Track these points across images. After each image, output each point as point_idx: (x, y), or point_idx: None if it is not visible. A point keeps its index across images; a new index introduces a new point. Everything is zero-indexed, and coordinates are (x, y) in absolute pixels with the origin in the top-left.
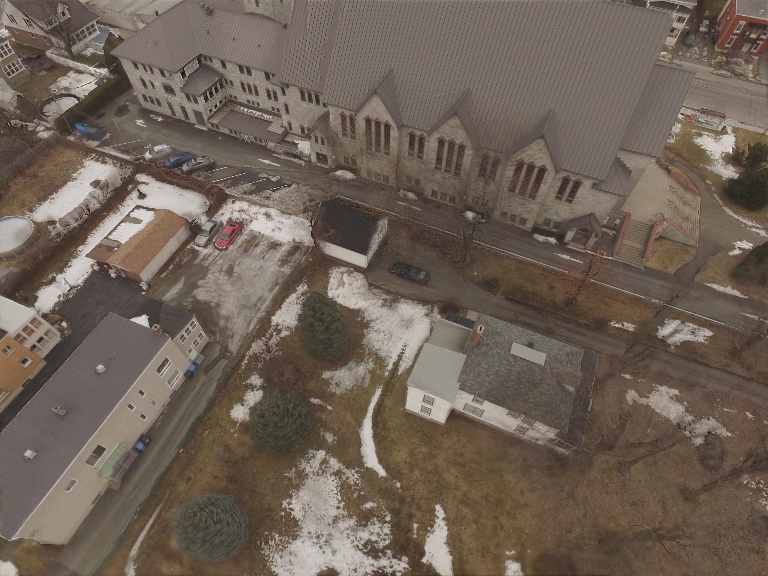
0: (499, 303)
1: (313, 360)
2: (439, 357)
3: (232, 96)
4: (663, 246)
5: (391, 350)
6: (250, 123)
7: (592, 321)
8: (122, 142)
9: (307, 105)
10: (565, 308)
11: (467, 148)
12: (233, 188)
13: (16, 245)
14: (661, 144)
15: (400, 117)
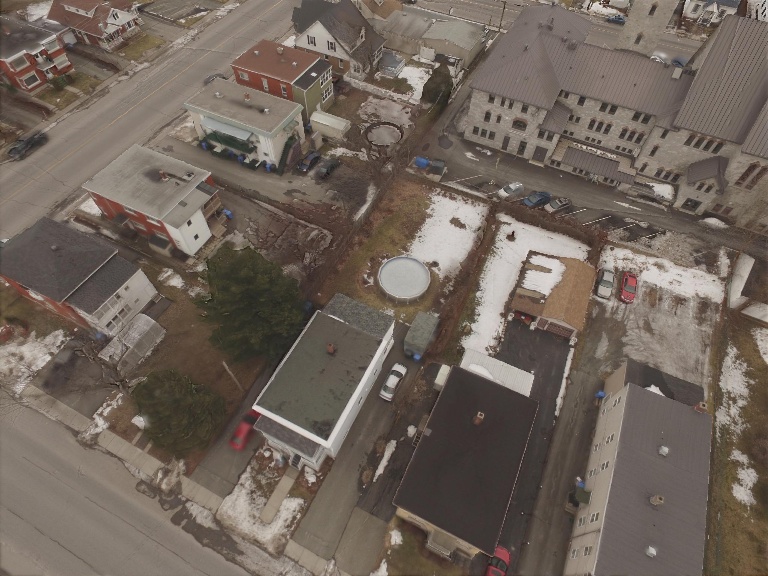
0: None
1: None
2: None
3: (568, 132)
4: None
5: None
6: (596, 162)
7: None
8: (464, 177)
9: (688, 149)
10: None
11: None
12: None
13: (421, 289)
14: None
15: None
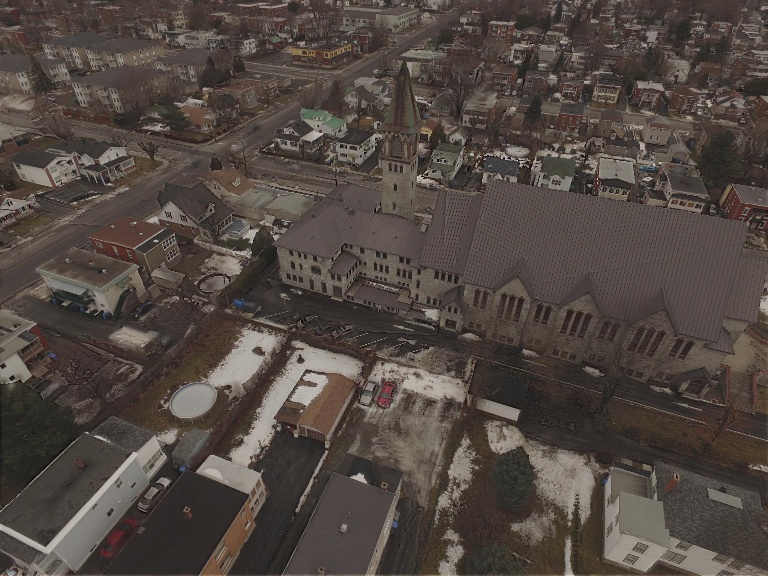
0: (645, 450)
1: (498, 512)
2: (638, 505)
3: (362, 273)
4: (763, 393)
5: (565, 500)
6: (381, 295)
7: (732, 465)
8: (273, 313)
9: (439, 282)
10: (704, 453)
11: (593, 317)
12: (380, 351)
13: (205, 409)
14: (755, 312)
15: (533, 293)
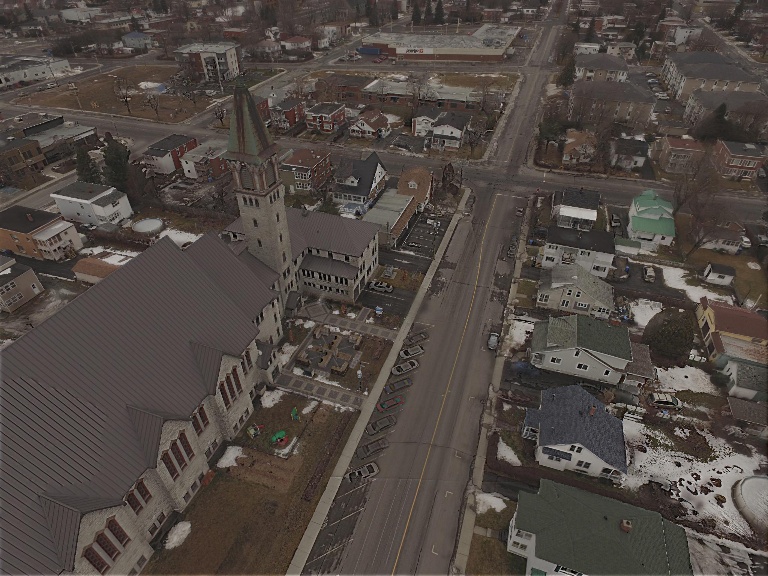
0: None
1: None
2: None
3: None
4: None
5: None
6: None
7: None
8: None
9: None
10: None
11: None
12: None
13: (137, 230)
14: None
15: None
